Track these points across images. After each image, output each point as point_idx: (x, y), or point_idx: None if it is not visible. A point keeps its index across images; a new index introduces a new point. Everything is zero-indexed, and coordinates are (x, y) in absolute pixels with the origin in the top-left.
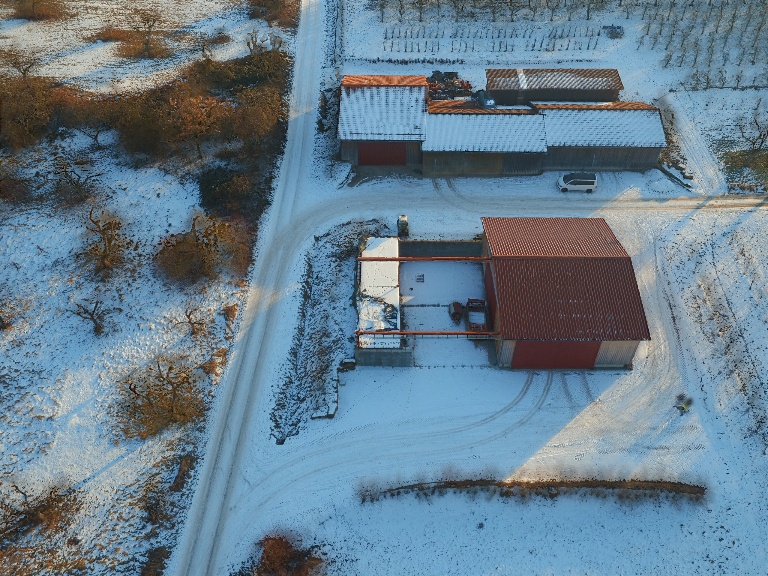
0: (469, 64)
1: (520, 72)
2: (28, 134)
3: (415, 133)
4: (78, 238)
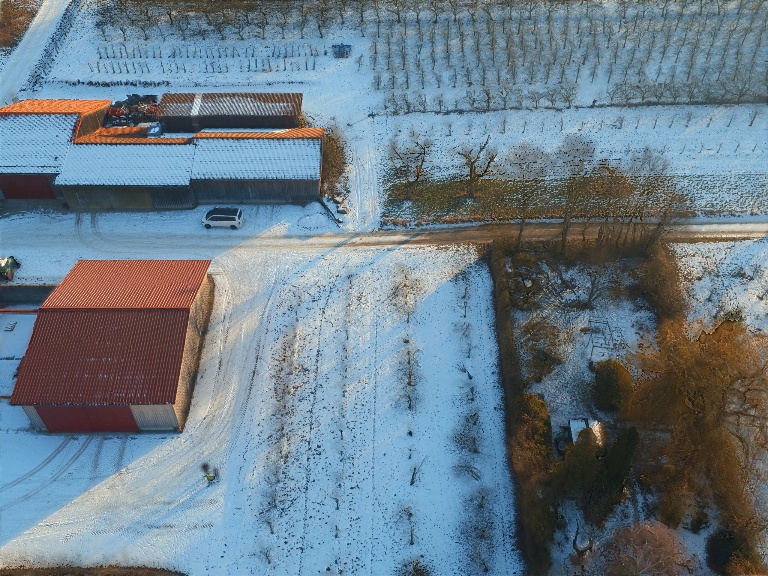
0: (175, 86)
1: (198, 97)
2: None
3: (52, 165)
4: None
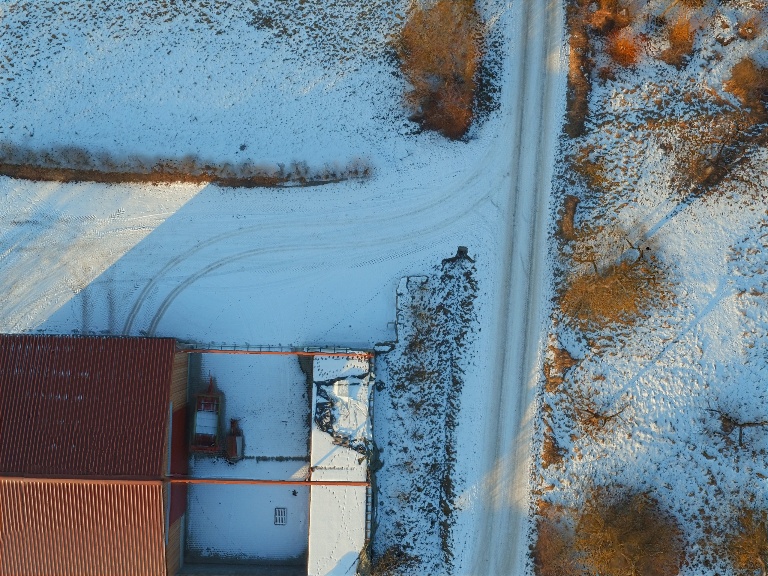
0: None
1: None
2: None
3: None
4: None
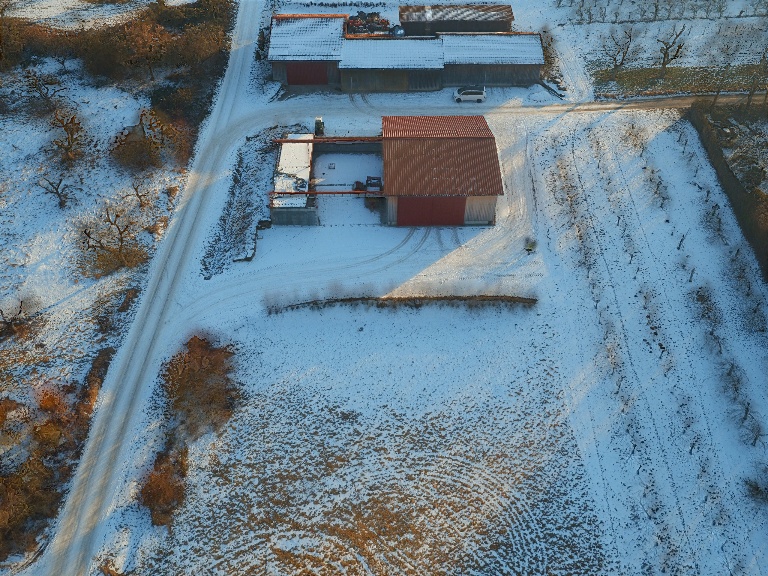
0: (390, 7)
1: (428, 8)
2: (5, 60)
3: (333, 54)
4: (47, 139)
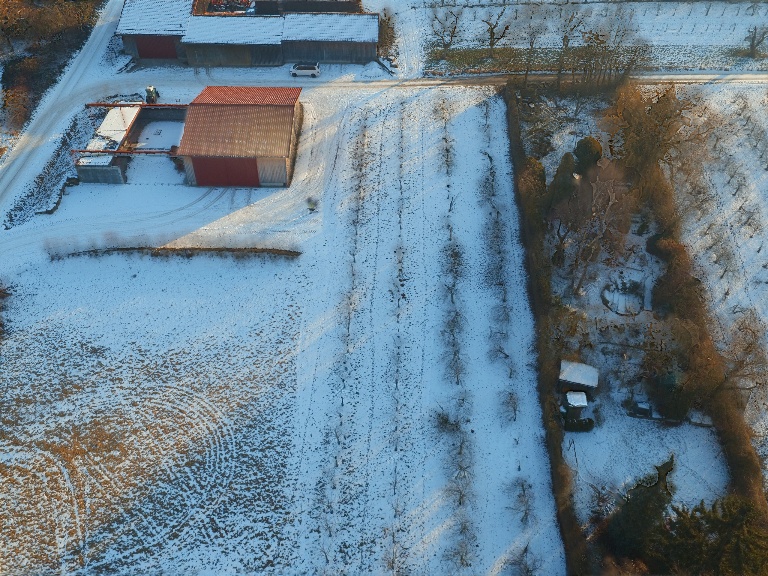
0: None
1: None
2: None
3: (178, 30)
4: None
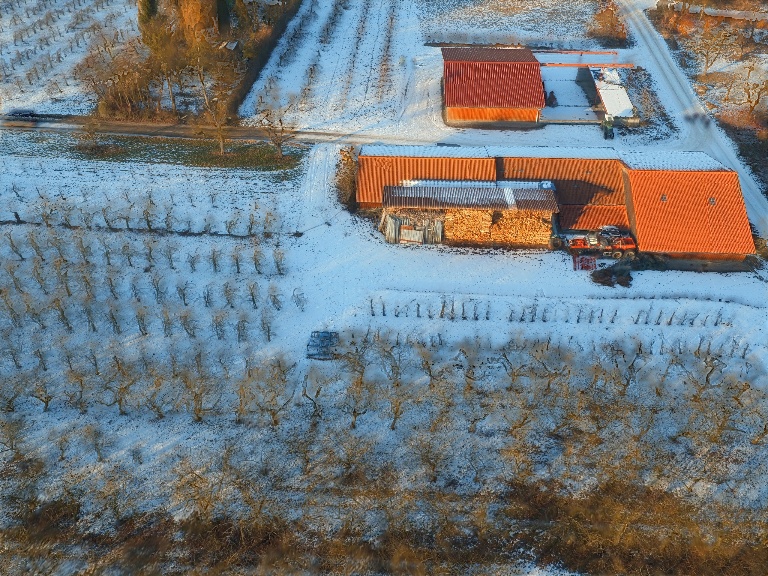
0: None
1: (513, 206)
2: None
3: (625, 152)
4: None
